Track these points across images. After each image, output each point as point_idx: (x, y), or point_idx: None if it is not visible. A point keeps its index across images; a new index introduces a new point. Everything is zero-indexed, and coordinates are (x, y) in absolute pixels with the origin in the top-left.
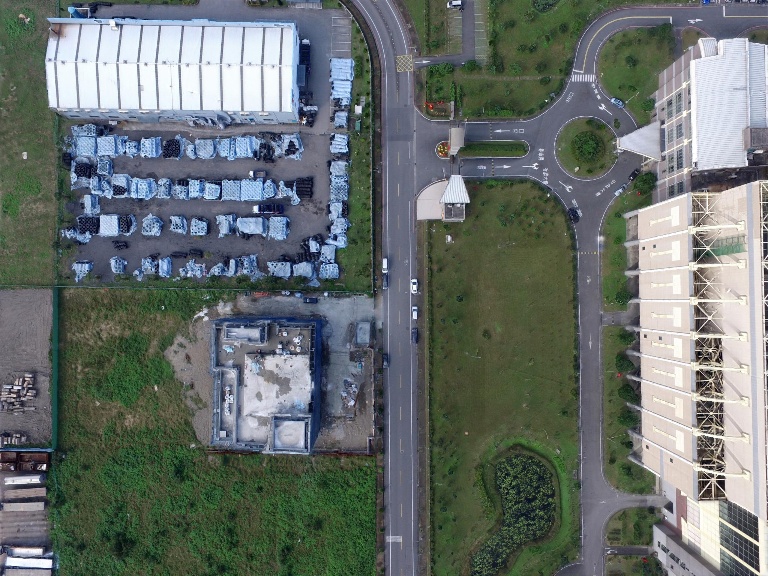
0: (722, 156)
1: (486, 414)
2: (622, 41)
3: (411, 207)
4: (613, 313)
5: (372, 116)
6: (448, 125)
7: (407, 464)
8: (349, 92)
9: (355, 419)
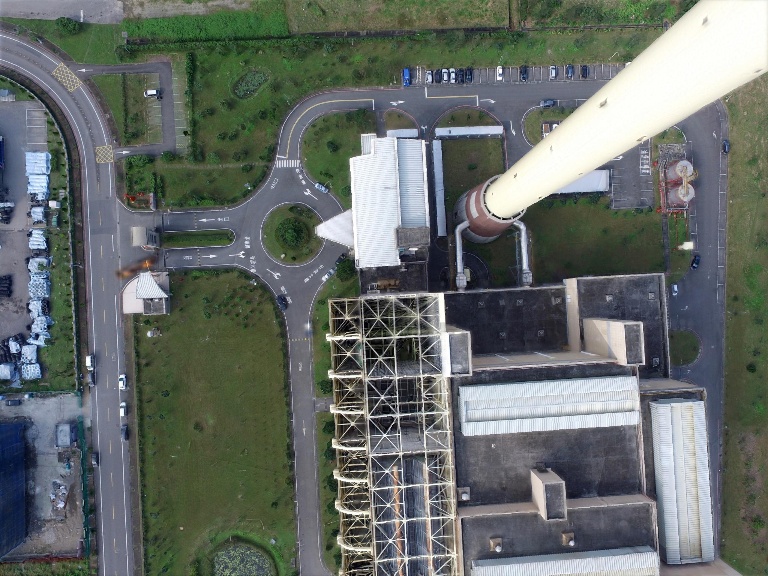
0: (377, 255)
1: (201, 508)
2: (324, 125)
3: (117, 301)
4: (326, 399)
5: (71, 210)
6: (152, 216)
7: (122, 563)
8: (45, 186)
9: (66, 521)
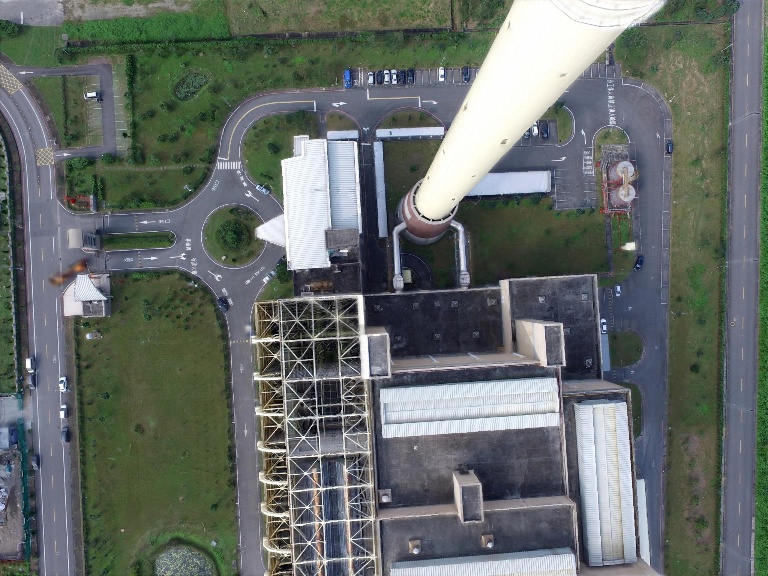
0: (307, 257)
1: (142, 510)
2: (265, 127)
3: (58, 303)
4: None
5: (11, 213)
6: (92, 218)
7: (63, 566)
8: None
9: (7, 524)
